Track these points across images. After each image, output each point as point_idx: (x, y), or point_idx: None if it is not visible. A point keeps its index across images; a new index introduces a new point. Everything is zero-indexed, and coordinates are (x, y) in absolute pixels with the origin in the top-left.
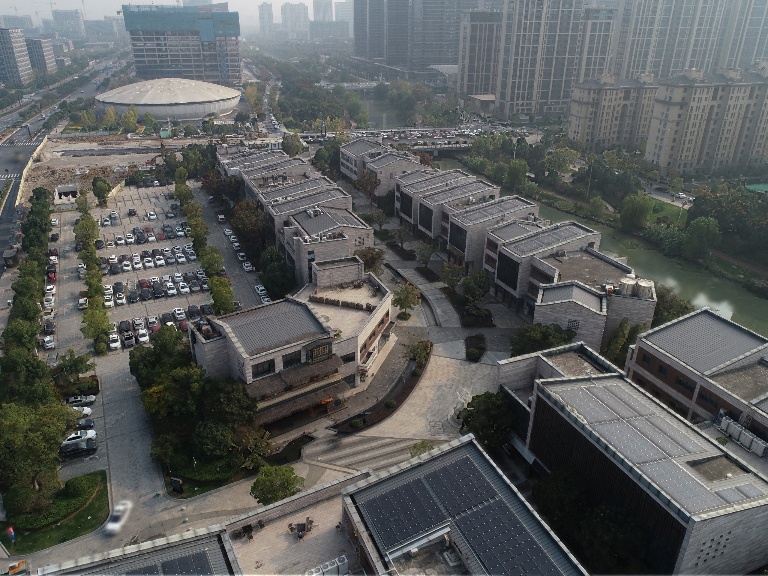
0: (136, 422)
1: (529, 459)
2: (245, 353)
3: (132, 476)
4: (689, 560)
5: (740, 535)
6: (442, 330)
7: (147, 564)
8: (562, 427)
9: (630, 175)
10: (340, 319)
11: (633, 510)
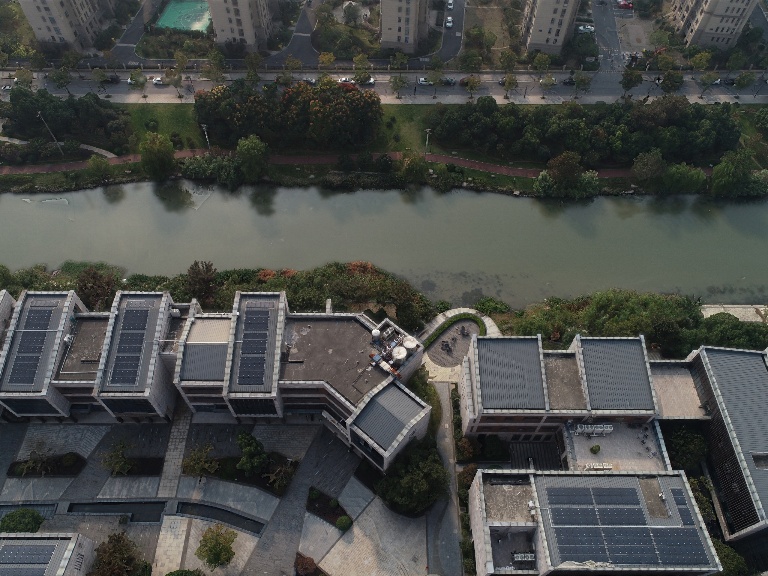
0: None
1: None
2: None
3: None
4: None
5: None
6: (276, 525)
7: None
8: None
9: (89, 100)
10: None
11: None
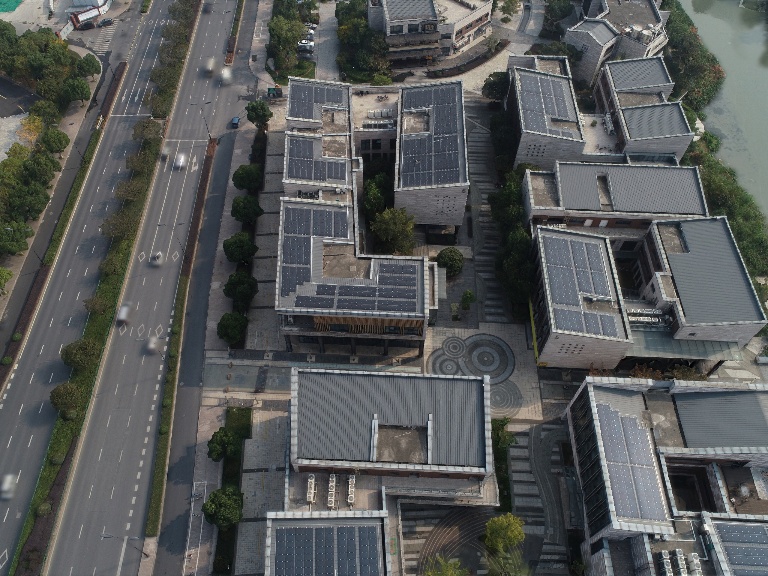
0: (333, 44)
1: (505, 109)
2: (388, 18)
3: (326, 68)
4: (522, 151)
5: (552, 150)
6: (524, 35)
7: (322, 87)
8: (514, 92)
9: None
10: (453, 11)
11: (516, 130)
